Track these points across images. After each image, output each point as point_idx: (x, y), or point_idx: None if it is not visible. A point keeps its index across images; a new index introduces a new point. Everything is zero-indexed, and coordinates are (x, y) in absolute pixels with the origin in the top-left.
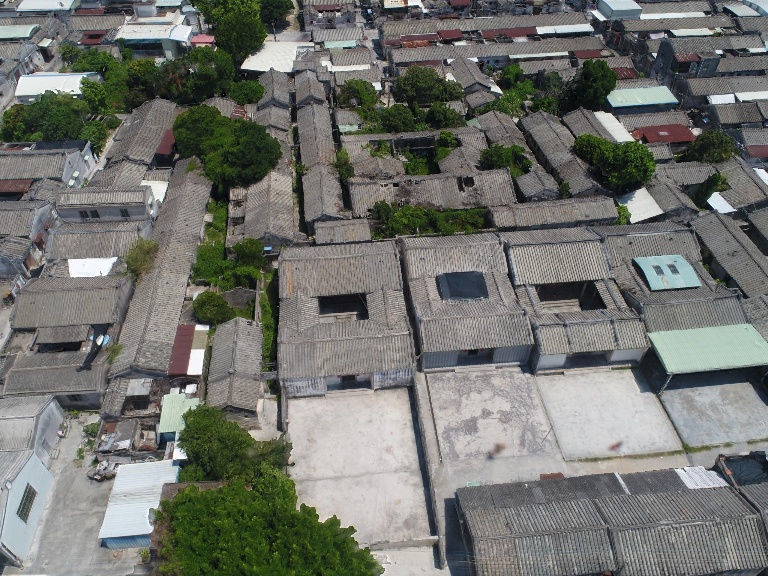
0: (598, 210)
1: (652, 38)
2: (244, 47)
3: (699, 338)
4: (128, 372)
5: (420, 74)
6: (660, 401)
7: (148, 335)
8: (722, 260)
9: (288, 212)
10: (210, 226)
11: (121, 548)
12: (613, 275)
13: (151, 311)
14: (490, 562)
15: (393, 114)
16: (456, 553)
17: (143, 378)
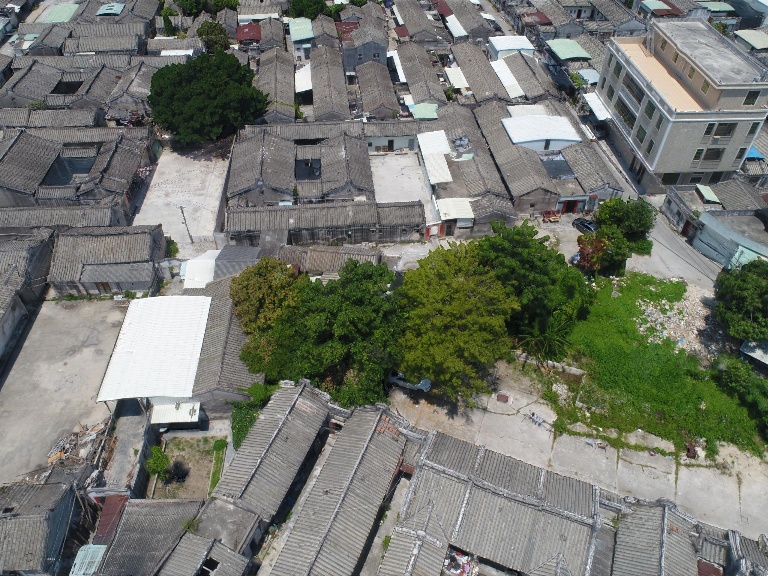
0: None
1: (452, 65)
2: None
3: None
4: None
5: None
6: None
7: None
8: None
9: None
10: None
11: None
12: (117, 0)
13: None
14: None
15: None
16: None
17: None
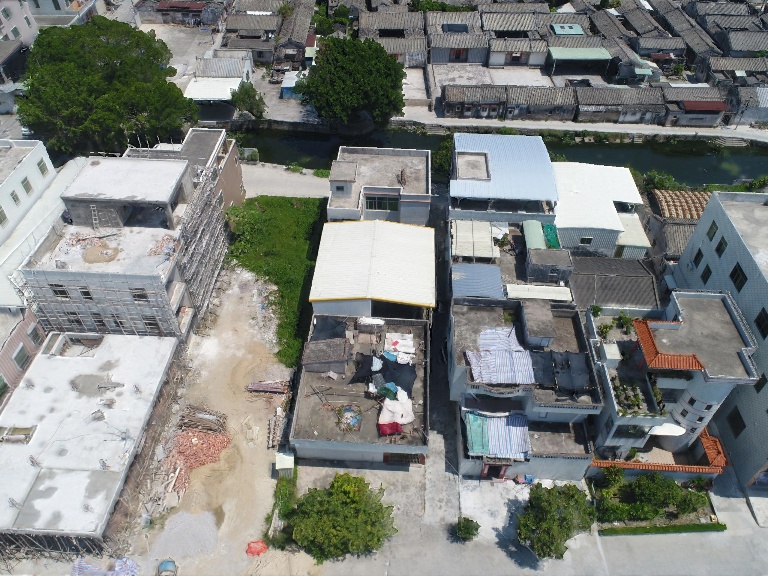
0: (538, 8)
1: None
2: None
3: (574, 49)
4: (287, 43)
5: None
6: (551, 79)
7: (295, 33)
8: (601, 28)
9: (363, 2)
10: (317, 13)
11: (288, 99)
12: (537, 29)
13: (295, 26)
14: (452, 94)
15: None
16: (439, 109)
17: (293, 49)
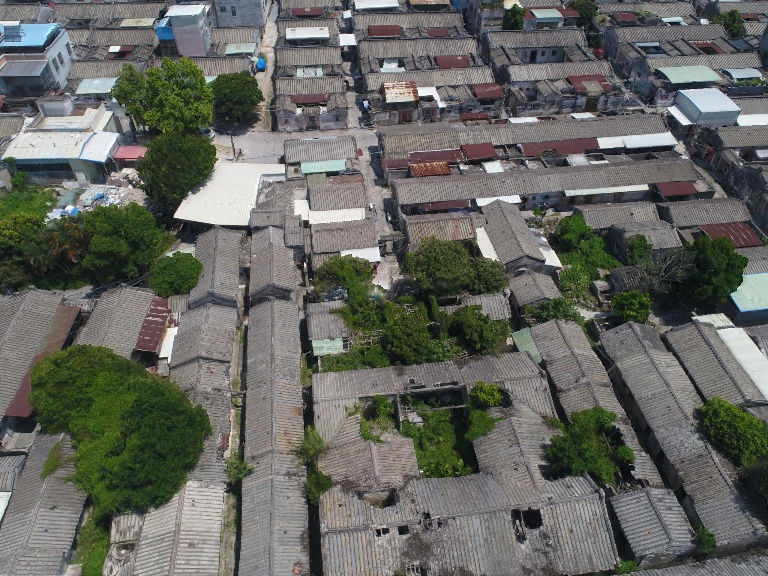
0: None
1: (759, 156)
2: (179, 186)
3: None
4: None
5: (441, 256)
6: None
7: None
8: None
9: None
10: None
11: None
12: None
13: None
14: None
15: (398, 336)
16: None
17: None
